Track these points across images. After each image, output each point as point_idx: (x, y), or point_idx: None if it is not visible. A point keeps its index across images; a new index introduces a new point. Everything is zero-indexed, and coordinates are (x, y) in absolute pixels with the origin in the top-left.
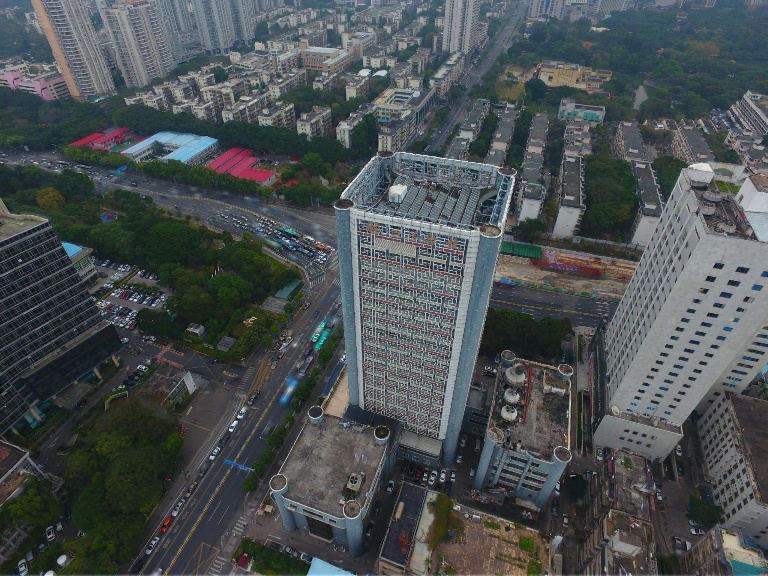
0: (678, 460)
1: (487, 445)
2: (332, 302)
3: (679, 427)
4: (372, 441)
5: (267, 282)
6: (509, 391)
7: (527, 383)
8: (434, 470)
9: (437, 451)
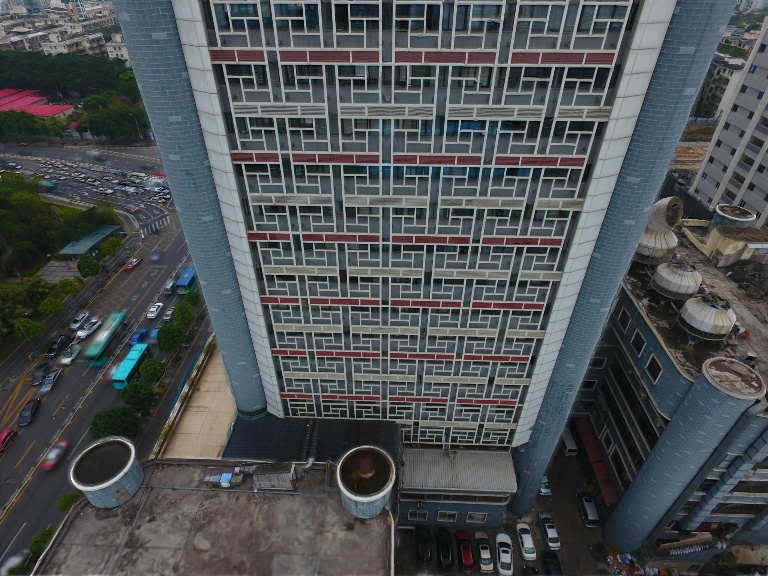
0: None
1: (707, 419)
2: (186, 249)
3: None
4: (335, 512)
5: (40, 231)
6: (674, 264)
7: None
8: (499, 533)
9: (509, 481)
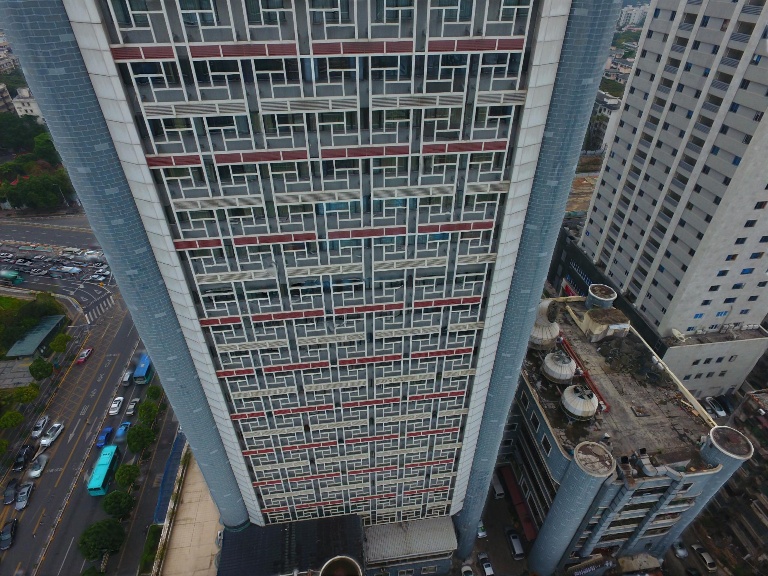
0: (749, 380)
1: (581, 489)
2: (136, 333)
3: (758, 328)
4: None
5: None
6: (555, 358)
7: (558, 336)
8: None
9: (451, 541)
